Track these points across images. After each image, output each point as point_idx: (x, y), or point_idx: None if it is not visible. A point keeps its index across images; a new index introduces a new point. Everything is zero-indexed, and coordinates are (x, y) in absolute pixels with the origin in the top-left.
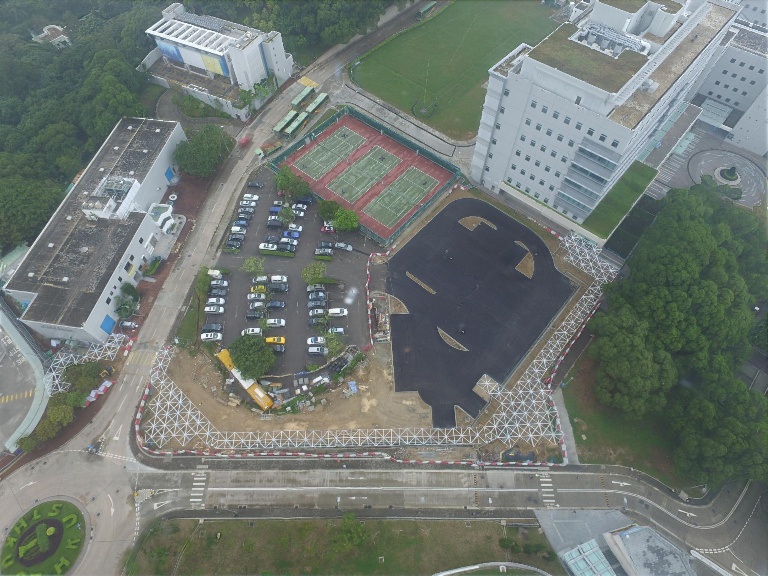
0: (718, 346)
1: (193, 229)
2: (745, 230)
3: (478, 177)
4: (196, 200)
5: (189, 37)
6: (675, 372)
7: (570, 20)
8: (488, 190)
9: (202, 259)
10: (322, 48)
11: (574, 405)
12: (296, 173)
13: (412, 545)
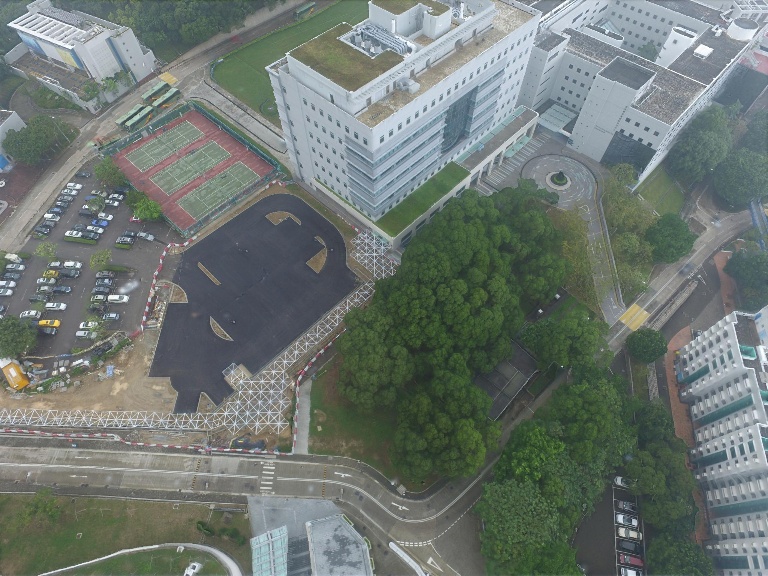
0: (465, 344)
1: (11, 215)
2: (534, 233)
3: (298, 174)
4: (23, 187)
5: (46, 31)
6: (410, 368)
7: None
8: (308, 187)
9: (10, 244)
10: (187, 45)
11: (319, 397)
12: (125, 164)
13: (114, 524)
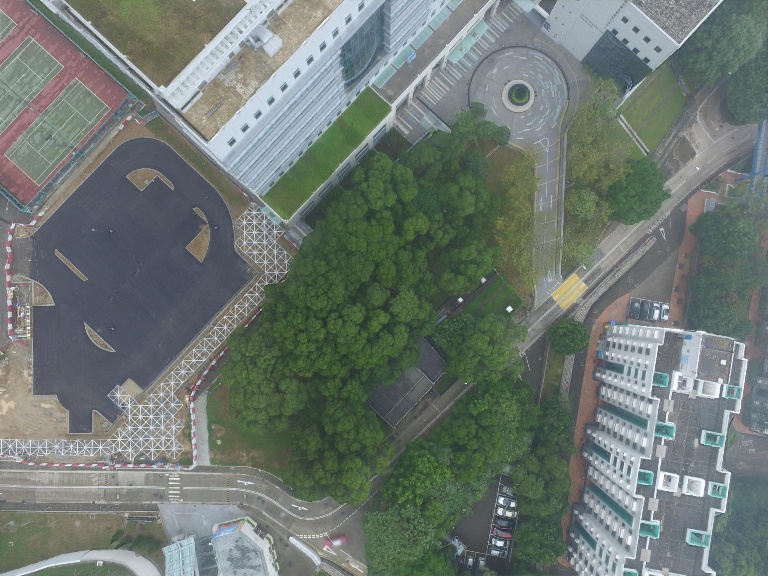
0: (362, 367)
1: None
2: (460, 213)
3: None
4: None
5: None
6: (302, 398)
7: None
8: None
9: None
10: None
11: (216, 411)
12: None
13: (40, 533)
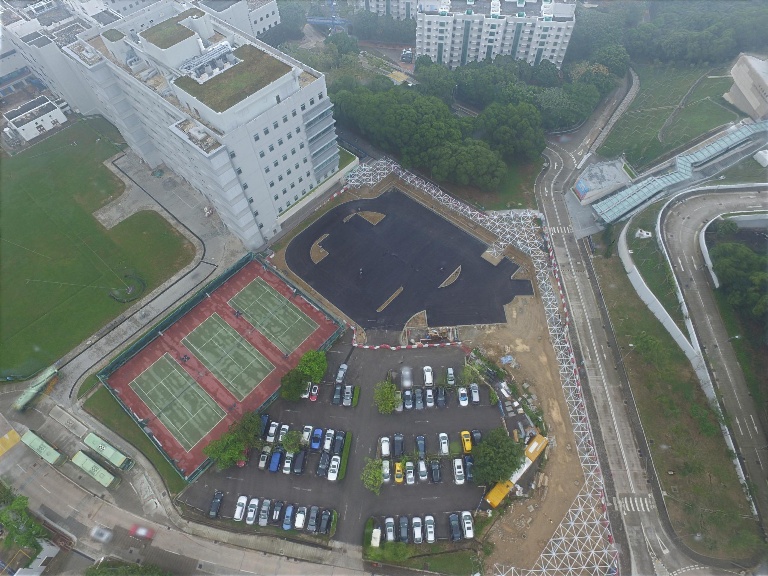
0: None
1: None
2: (354, 84)
3: (260, 241)
4: None
5: None
6: None
7: (28, 140)
8: (274, 238)
9: (344, 570)
10: None
11: (497, 205)
12: (207, 444)
13: (626, 313)
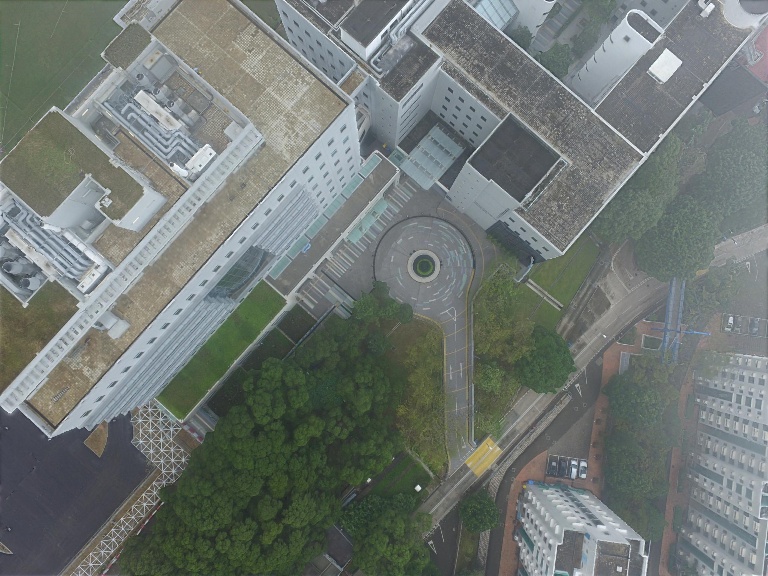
0: None
1: None
2: None
3: None
4: None
5: None
6: None
7: None
8: None
9: None
10: None
11: None
12: None
13: None
